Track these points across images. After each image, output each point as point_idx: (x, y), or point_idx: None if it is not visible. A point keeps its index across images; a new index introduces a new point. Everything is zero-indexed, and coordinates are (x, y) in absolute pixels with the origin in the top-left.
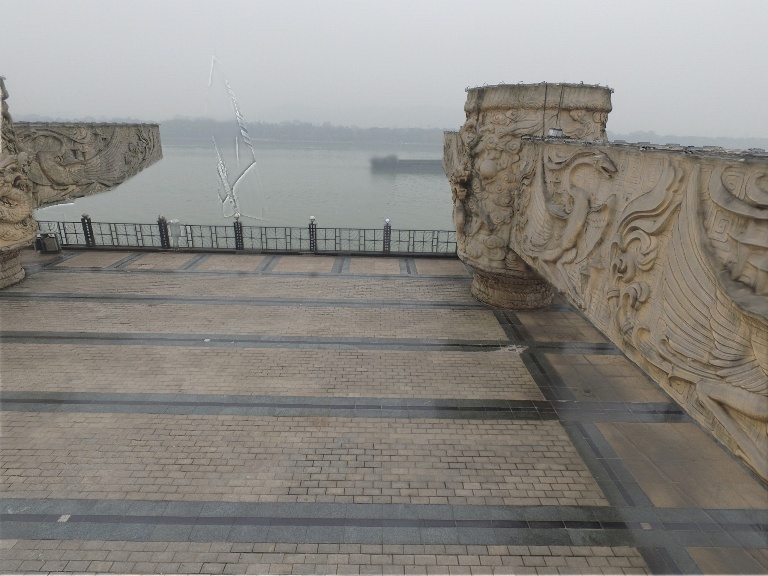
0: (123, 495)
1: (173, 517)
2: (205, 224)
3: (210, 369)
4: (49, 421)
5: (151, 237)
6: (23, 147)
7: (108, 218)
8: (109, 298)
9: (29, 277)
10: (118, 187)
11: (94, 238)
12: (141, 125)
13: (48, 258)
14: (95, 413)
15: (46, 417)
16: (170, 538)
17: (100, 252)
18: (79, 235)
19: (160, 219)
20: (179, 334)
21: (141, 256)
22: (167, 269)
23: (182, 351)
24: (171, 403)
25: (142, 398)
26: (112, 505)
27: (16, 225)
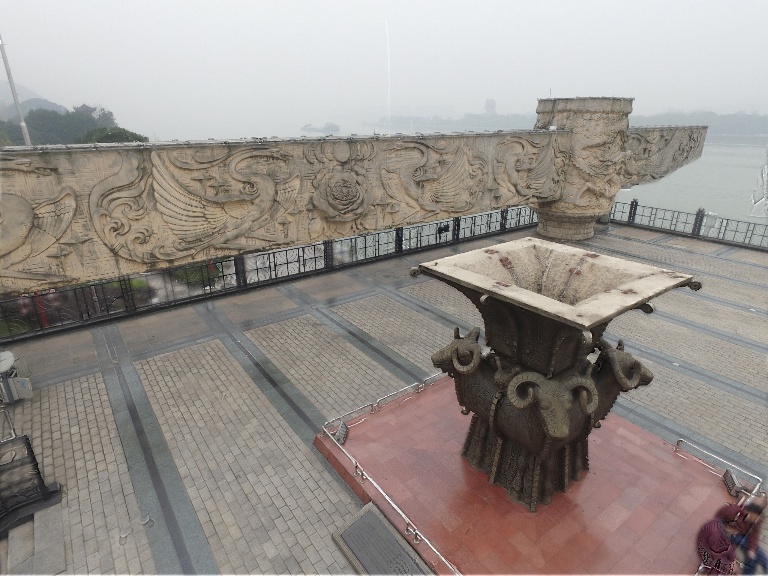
0: (710, 369)
1: (750, 392)
2: (744, 220)
3: (760, 328)
4: (646, 318)
5: (685, 224)
6: (627, 146)
7: (652, 204)
8: (657, 262)
9: (594, 236)
10: (660, 180)
11: (635, 218)
12: (695, 127)
13: (601, 226)
14: (675, 324)
15: (643, 316)
16: (751, 400)
17: (637, 229)
18: (624, 214)
19: (700, 210)
20: (725, 299)
21: (672, 238)
22: (699, 252)
23: (731, 310)
24: (731, 337)
25: (706, 327)
26: (704, 370)
27: (607, 199)
